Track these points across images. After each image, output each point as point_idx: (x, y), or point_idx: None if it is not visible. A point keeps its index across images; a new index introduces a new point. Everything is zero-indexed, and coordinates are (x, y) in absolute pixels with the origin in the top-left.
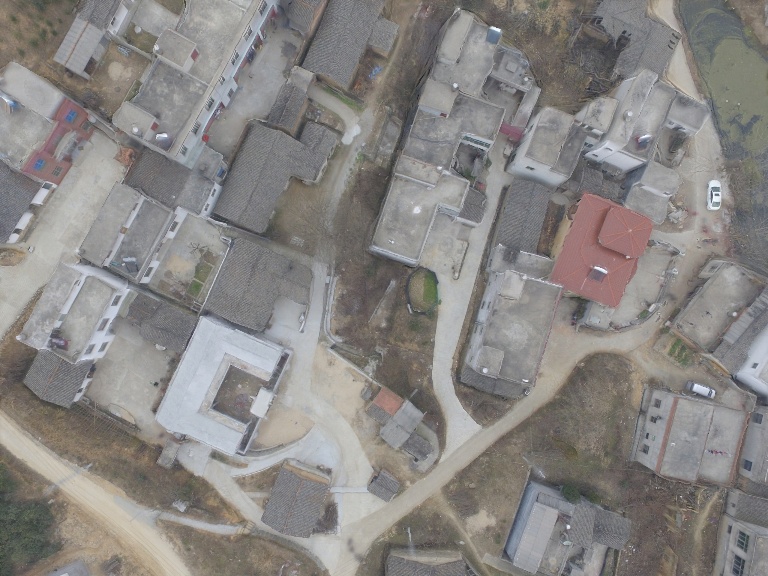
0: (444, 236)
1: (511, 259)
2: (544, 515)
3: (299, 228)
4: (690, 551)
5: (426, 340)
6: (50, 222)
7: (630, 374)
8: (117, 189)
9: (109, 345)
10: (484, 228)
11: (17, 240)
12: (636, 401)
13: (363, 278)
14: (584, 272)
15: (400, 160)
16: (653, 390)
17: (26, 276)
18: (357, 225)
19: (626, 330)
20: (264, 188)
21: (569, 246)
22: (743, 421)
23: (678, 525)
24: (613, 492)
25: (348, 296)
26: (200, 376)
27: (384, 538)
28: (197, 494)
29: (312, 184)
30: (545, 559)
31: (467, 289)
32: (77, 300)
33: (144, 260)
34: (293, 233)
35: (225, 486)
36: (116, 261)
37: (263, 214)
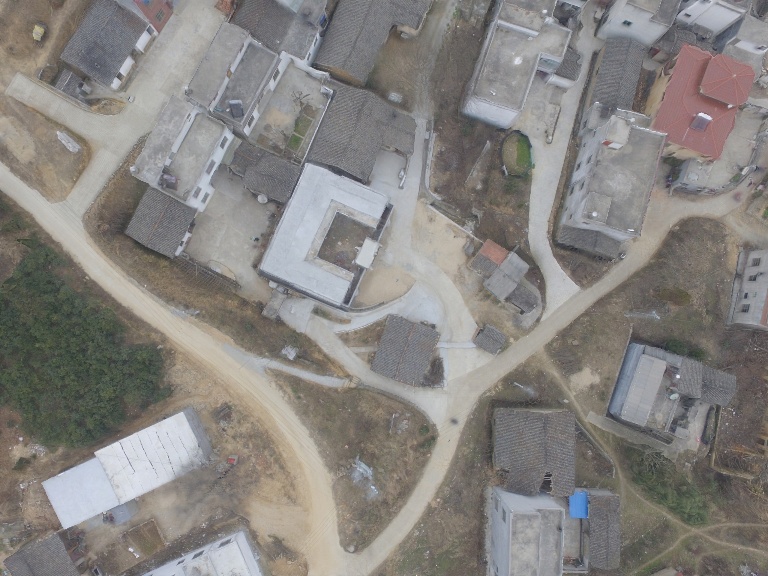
0: (536, 100)
1: (609, 115)
2: (652, 366)
3: (397, 84)
4: None
5: (521, 203)
6: (150, 72)
7: (725, 237)
8: (225, 28)
9: (209, 199)
10: (576, 93)
11: (119, 87)
12: (732, 264)
13: (460, 137)
14: (687, 121)
15: (504, 6)
16: (749, 252)
17: (127, 125)
18: (452, 85)
19: (721, 191)
20: (368, 35)
21: (670, 96)
22: None
23: None
24: (714, 351)
25: (447, 152)
26: (308, 221)
27: (490, 393)
28: (303, 346)
29: (411, 37)
30: (651, 414)
31: (560, 153)
32: (186, 138)
33: (250, 104)
34: (391, 89)
35: (328, 342)
36: (220, 107)
37: (366, 62)
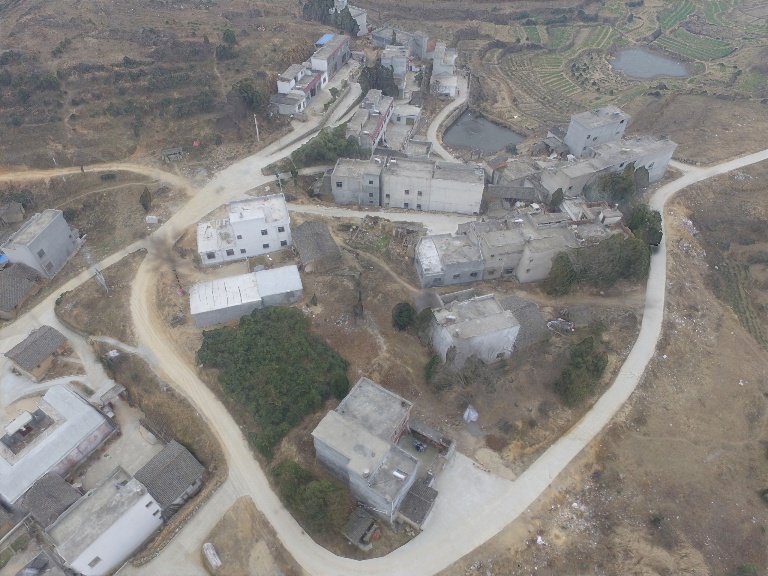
0: None
1: None
2: None
3: None
4: None
5: None
6: None
7: None
8: None
9: None
10: None
11: None
12: None
13: None
14: None
15: None
16: None
17: None
18: None
19: None
20: None
21: None
22: None
23: None
24: None
25: None
26: None
27: (6, 324)
28: None
29: None
30: None
31: None
32: None
33: (23, 570)
34: None
35: (95, 370)
36: None
37: None
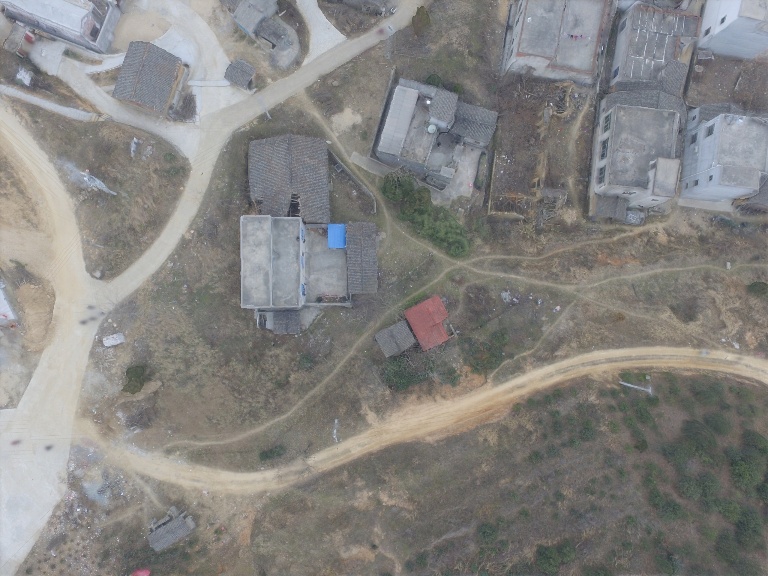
0: None
1: None
2: (405, 96)
3: None
4: (565, 163)
5: None
6: None
7: None
8: None
9: None
10: None
11: None
12: (503, 16)
13: None
14: None
15: None
16: (518, 2)
17: None
18: None
19: None
20: None
21: None
22: (602, 8)
23: (546, 120)
24: (481, 95)
25: None
26: None
27: (245, 128)
28: (47, 79)
29: None
30: (412, 149)
31: None
32: None
33: None
34: None
35: (80, 83)
36: None
37: None
